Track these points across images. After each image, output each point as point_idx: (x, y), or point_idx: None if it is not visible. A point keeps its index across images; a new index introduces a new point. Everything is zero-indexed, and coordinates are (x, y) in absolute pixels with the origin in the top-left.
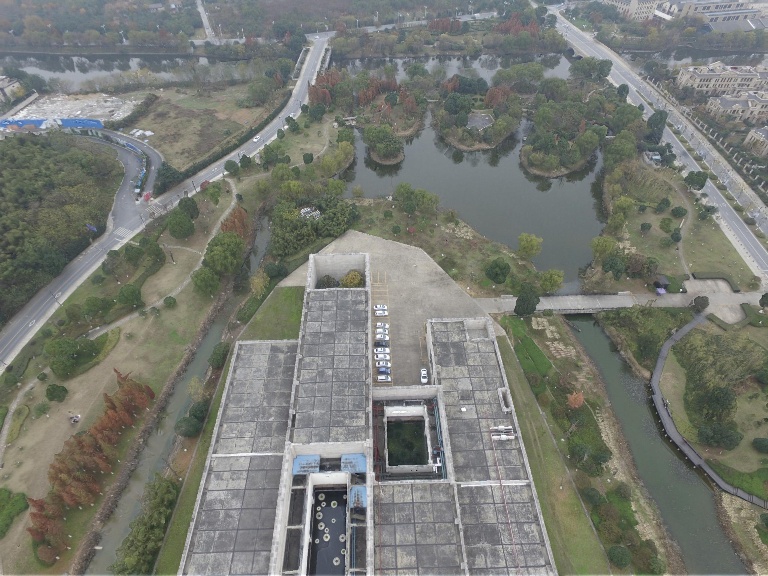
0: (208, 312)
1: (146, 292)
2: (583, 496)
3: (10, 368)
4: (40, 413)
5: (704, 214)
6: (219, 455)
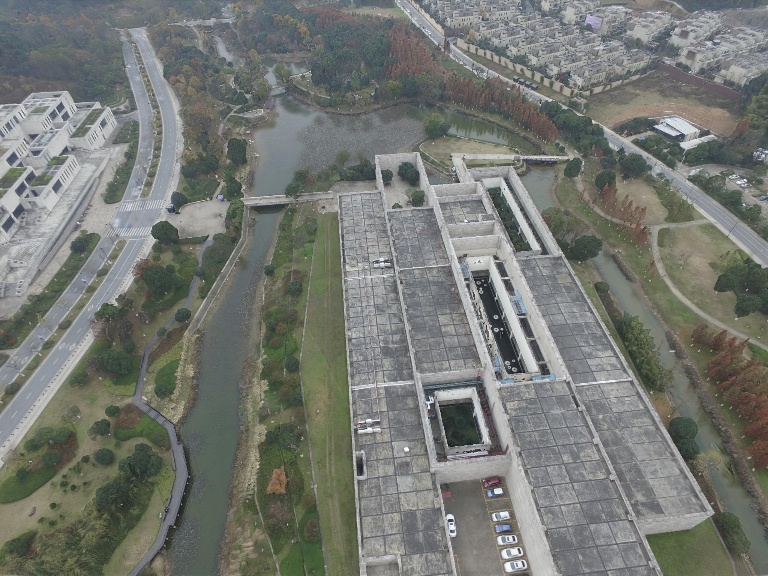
0: None
1: None
2: None
3: None
4: None
5: None
6: (626, 379)
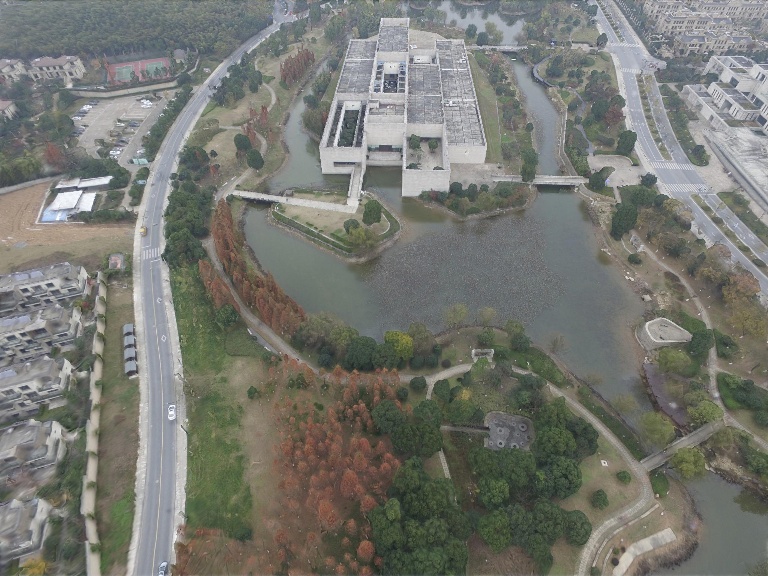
0: (331, 47)
1: (301, 38)
2: (492, 84)
3: (249, 54)
4: (272, 57)
5: (589, 22)
6: (349, 59)
